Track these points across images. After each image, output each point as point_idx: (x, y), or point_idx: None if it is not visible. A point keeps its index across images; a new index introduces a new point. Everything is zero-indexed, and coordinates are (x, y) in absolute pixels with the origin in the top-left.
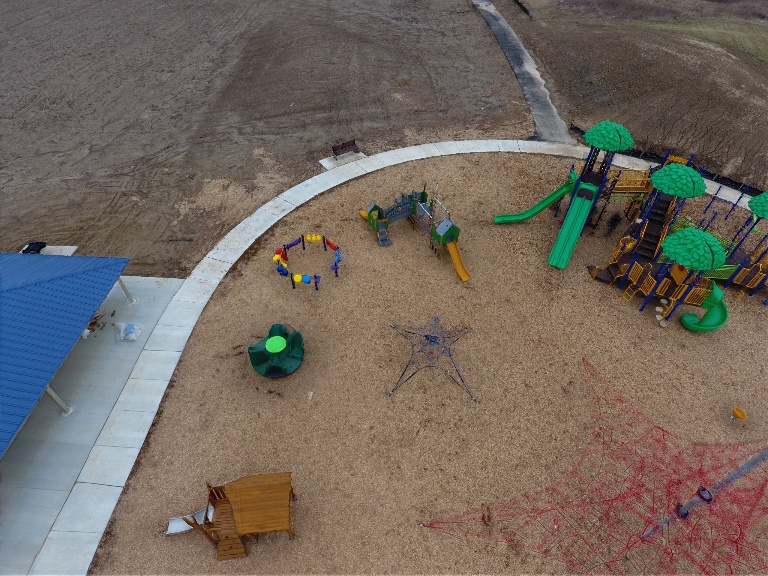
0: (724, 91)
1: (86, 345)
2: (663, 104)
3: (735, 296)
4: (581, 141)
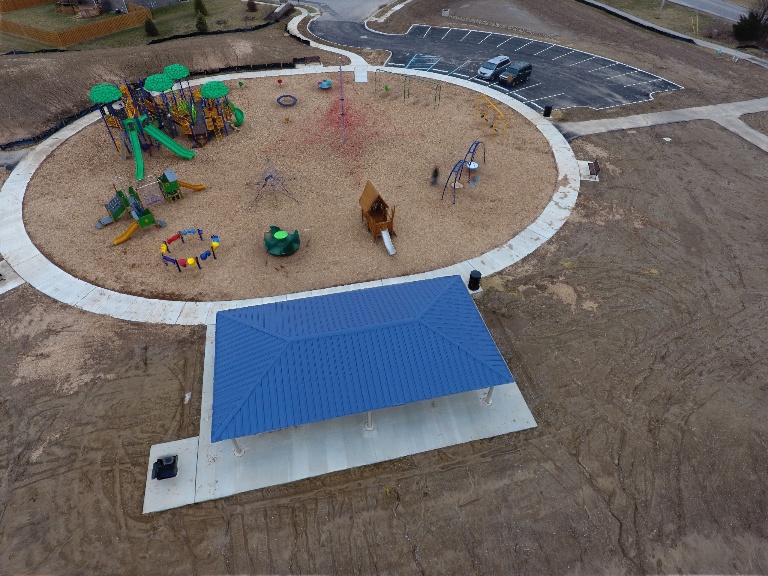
0: (6, 73)
1: None
2: (3, 100)
3: None
4: (27, 146)
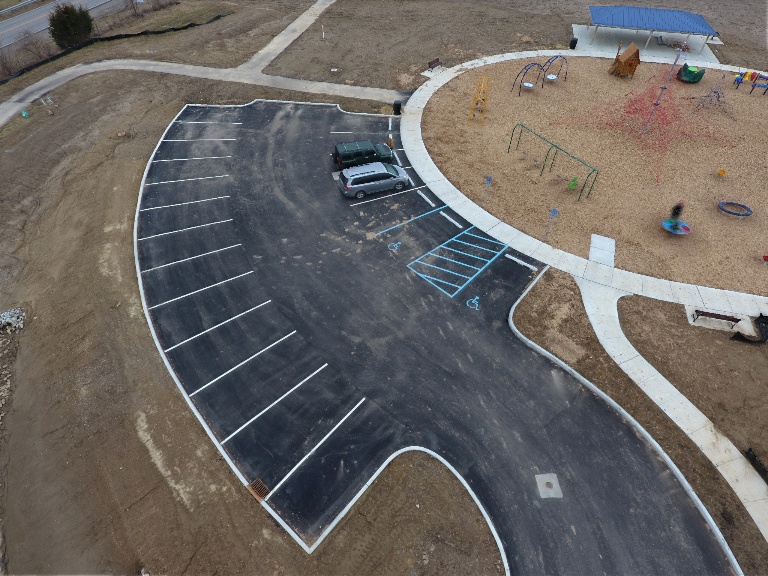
0: None
1: (672, 50)
2: None
3: None
4: None
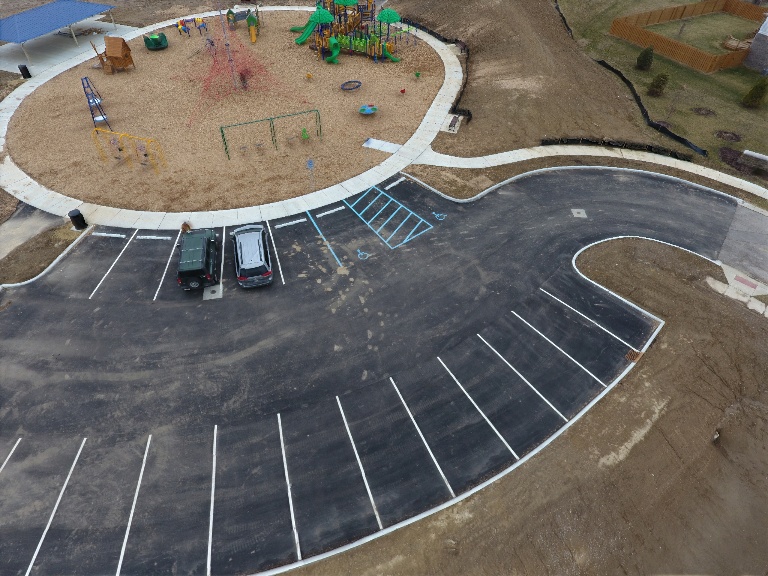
0: None
1: (93, 36)
2: None
3: (367, 60)
4: None
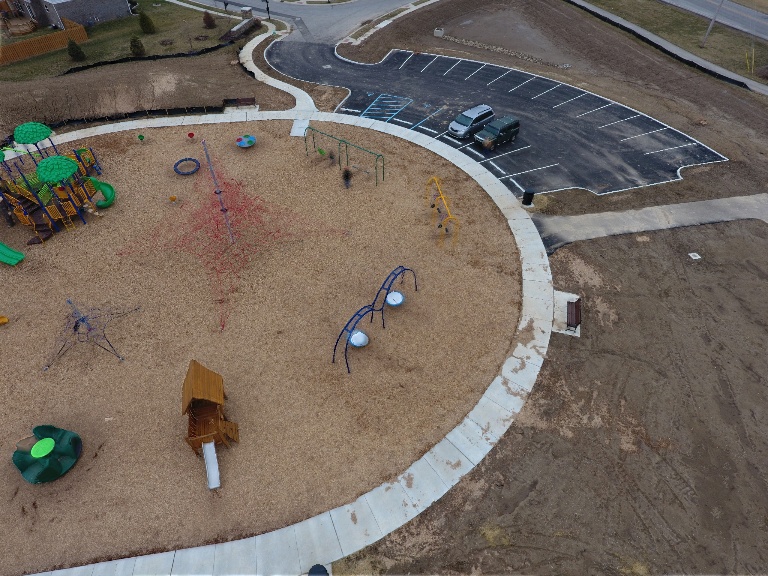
0: None
1: None
2: None
3: None
4: None
